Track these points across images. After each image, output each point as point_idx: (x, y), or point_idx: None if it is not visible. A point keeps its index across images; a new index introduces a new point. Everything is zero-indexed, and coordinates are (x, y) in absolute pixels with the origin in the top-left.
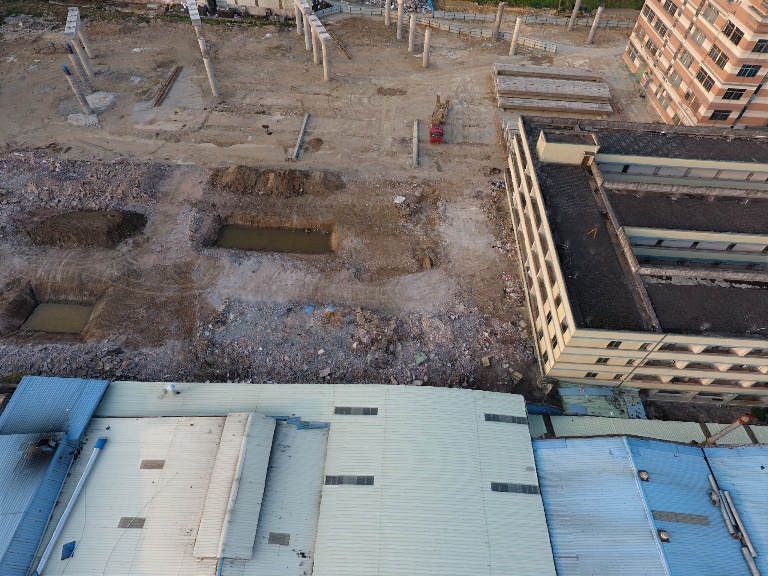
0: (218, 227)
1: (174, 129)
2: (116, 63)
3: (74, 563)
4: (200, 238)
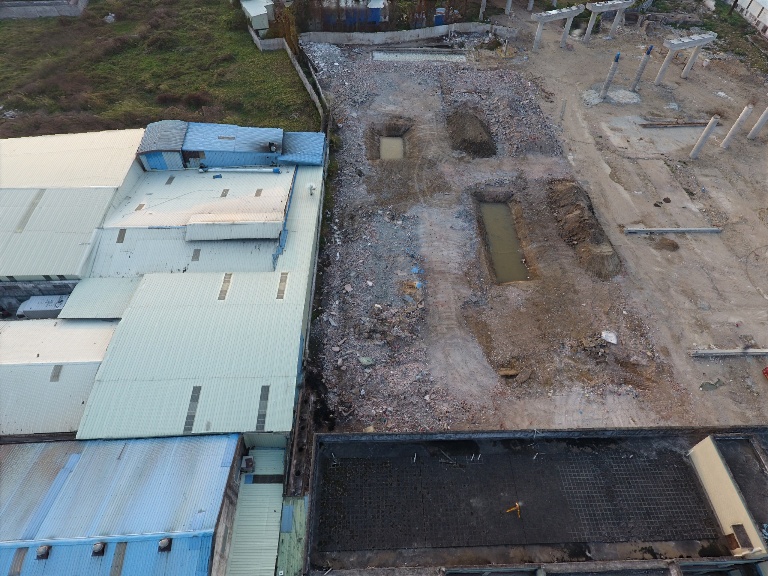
0: (501, 198)
1: (615, 143)
2: (687, 90)
3: (210, 180)
4: (481, 189)
